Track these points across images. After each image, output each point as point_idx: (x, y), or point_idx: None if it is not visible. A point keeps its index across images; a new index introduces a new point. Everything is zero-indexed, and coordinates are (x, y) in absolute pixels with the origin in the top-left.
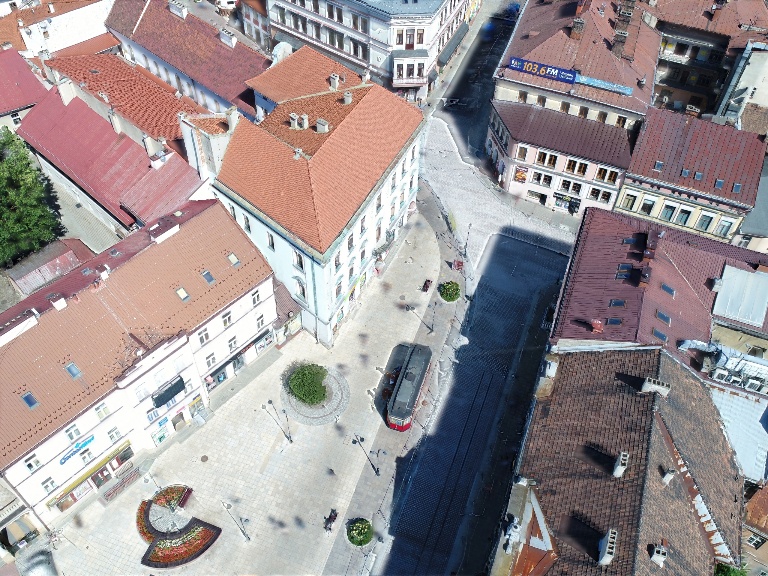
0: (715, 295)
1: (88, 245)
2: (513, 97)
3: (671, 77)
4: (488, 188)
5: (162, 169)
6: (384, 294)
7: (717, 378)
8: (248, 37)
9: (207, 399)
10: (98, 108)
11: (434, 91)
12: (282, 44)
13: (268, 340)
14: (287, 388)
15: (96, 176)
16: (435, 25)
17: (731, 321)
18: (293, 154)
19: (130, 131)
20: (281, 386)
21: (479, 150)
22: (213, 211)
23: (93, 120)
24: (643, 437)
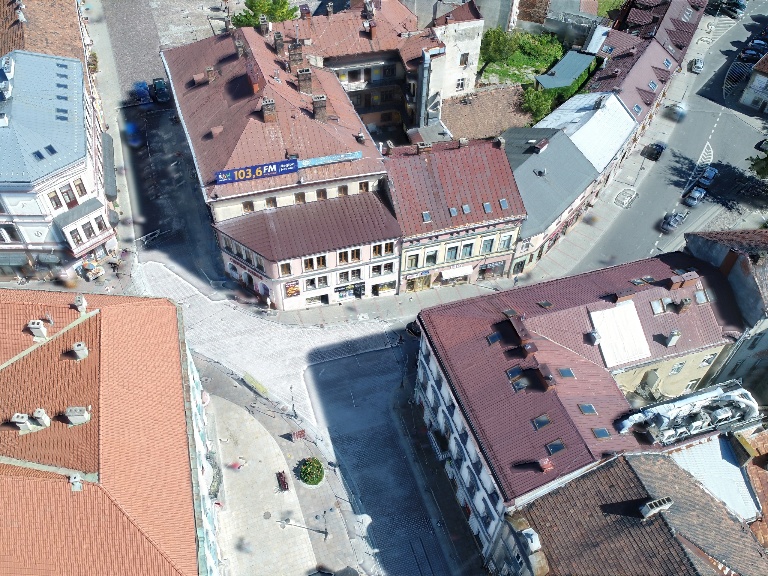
0: (599, 348)
1: None
2: (237, 212)
3: (355, 105)
4: (261, 318)
5: None
6: (244, 526)
7: (666, 440)
8: None
9: None
10: None
11: (119, 230)
12: None
13: None
14: None
15: None
16: (88, 164)
17: (625, 365)
18: (68, 486)
19: None
20: None
21: None
22: None
23: None
24: (690, 575)
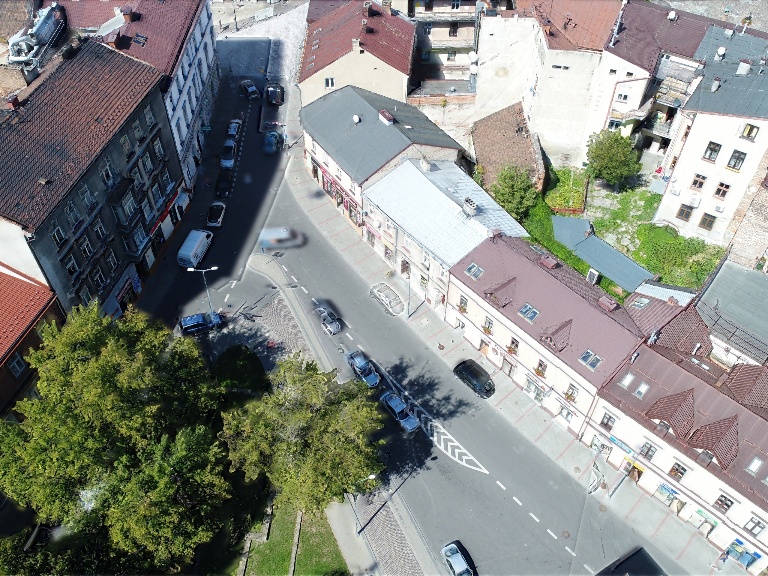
0: None
1: None
2: None
3: None
4: None
5: None
6: None
7: None
8: None
9: None
10: None
11: None
12: None
13: None
14: None
15: None
16: None
17: None
18: None
19: None
20: None
21: None
22: None
23: None
24: None
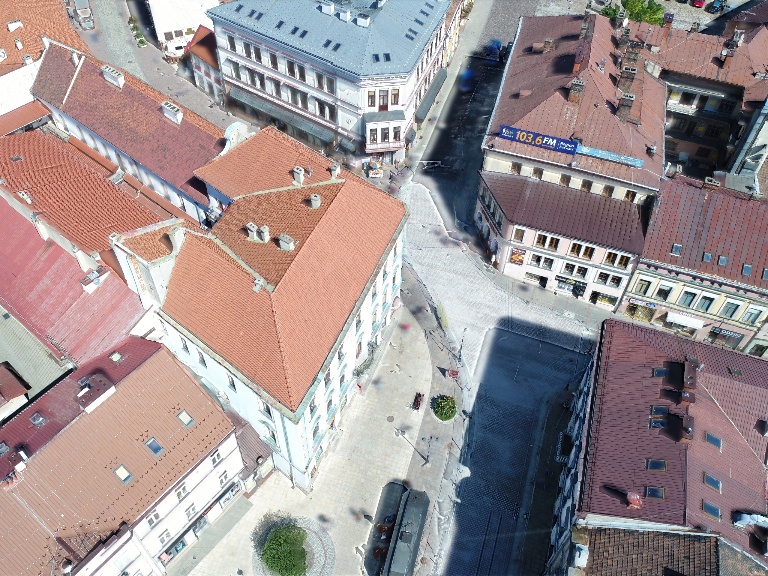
0: (767, 441)
1: (17, 369)
2: (505, 168)
3: (676, 128)
4: (480, 270)
5: (96, 293)
6: (369, 415)
7: None
8: (200, 89)
9: (163, 575)
10: (20, 209)
11: (412, 150)
12: (235, 125)
13: (234, 490)
14: (259, 551)
15: (20, 294)
16: (411, 82)
17: None
18: (252, 285)
19: (58, 239)
20: (252, 549)
21: (467, 224)
22: (157, 359)
23: (15, 222)
24: None
